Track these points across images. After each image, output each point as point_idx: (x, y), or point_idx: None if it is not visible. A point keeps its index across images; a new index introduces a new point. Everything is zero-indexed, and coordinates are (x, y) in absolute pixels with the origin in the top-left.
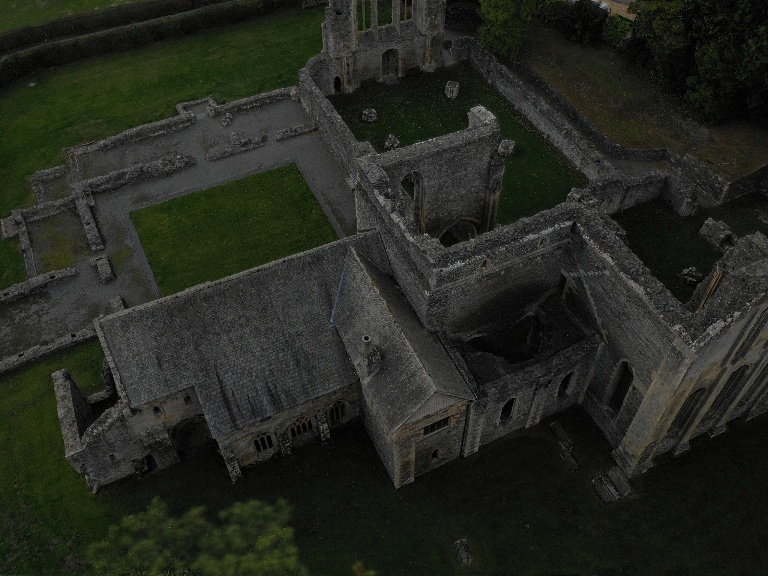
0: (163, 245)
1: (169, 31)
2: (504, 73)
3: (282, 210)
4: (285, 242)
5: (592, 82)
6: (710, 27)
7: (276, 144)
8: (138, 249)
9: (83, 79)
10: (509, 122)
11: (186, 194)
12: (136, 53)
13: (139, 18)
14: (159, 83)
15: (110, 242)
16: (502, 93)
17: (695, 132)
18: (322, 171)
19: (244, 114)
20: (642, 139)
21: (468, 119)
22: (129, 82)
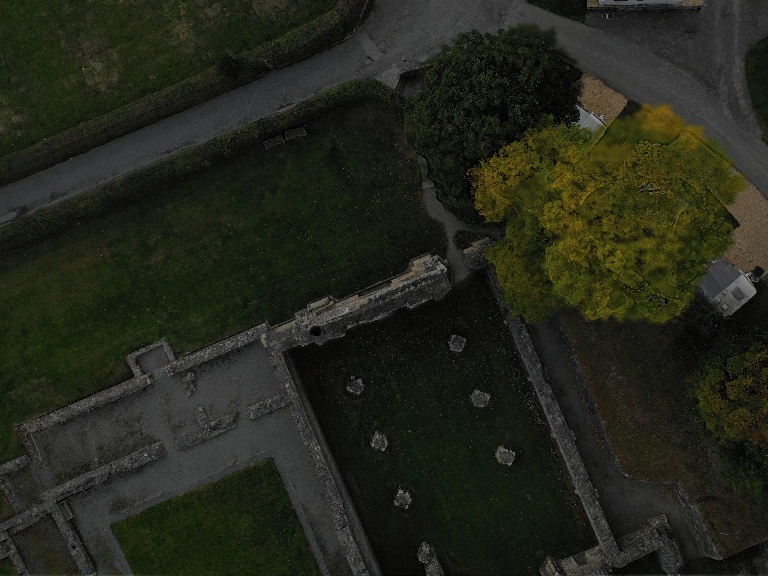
0: (153, 573)
1: (89, 213)
2: (523, 339)
3: (264, 531)
4: (270, 575)
5: (625, 373)
6: (766, 469)
7: (250, 425)
8: (130, 575)
9: (1, 299)
10: (516, 403)
11: (163, 501)
12: (54, 244)
13: (40, 168)
14: (97, 312)
15: (101, 565)
16: (517, 347)
17: (718, 466)
18: (303, 474)
19: (208, 371)
20: (656, 469)
21: (470, 394)
22: (59, 307)
